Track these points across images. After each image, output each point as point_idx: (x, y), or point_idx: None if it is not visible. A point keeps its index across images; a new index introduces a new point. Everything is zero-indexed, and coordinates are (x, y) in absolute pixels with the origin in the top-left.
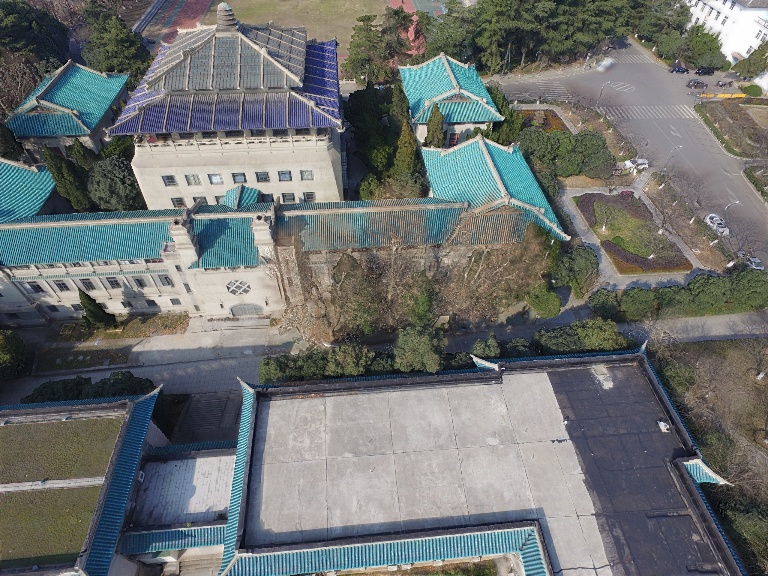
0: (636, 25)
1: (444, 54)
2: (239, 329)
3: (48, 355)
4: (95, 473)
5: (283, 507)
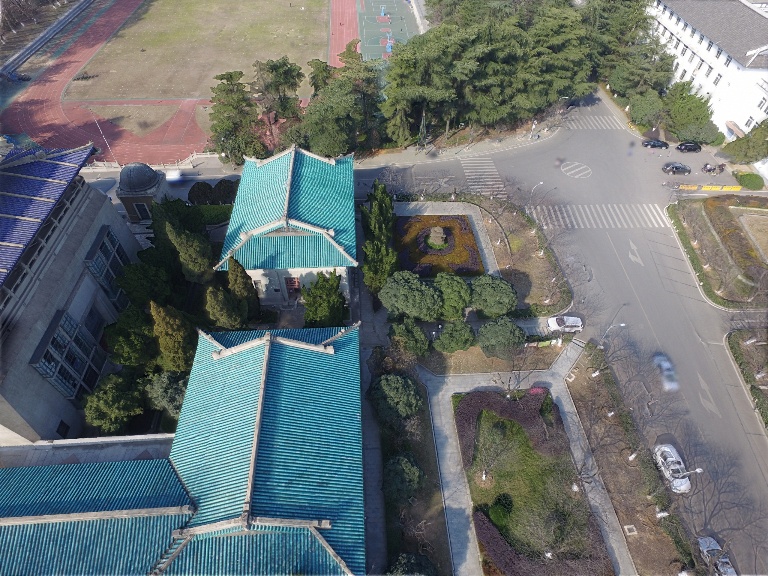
0: (606, 76)
1: (296, 147)
2: None
3: None
4: None
5: None
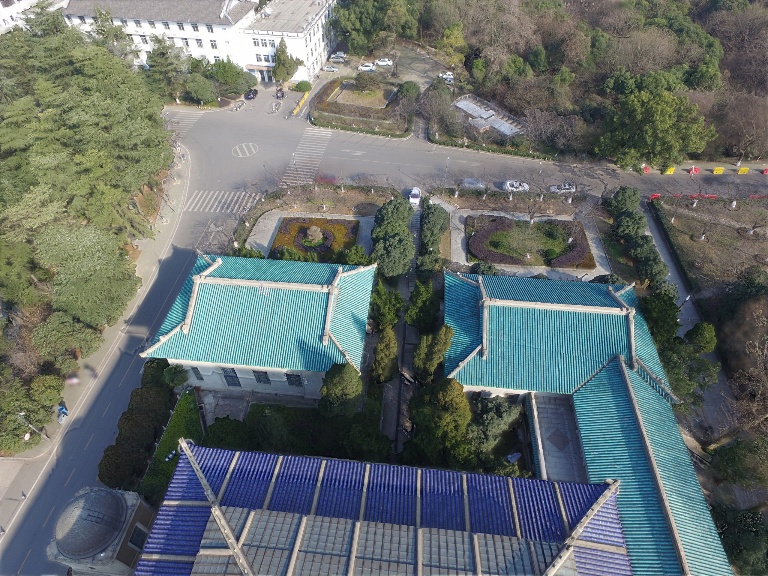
0: None
1: (198, 276)
2: None
3: None
4: None
5: None
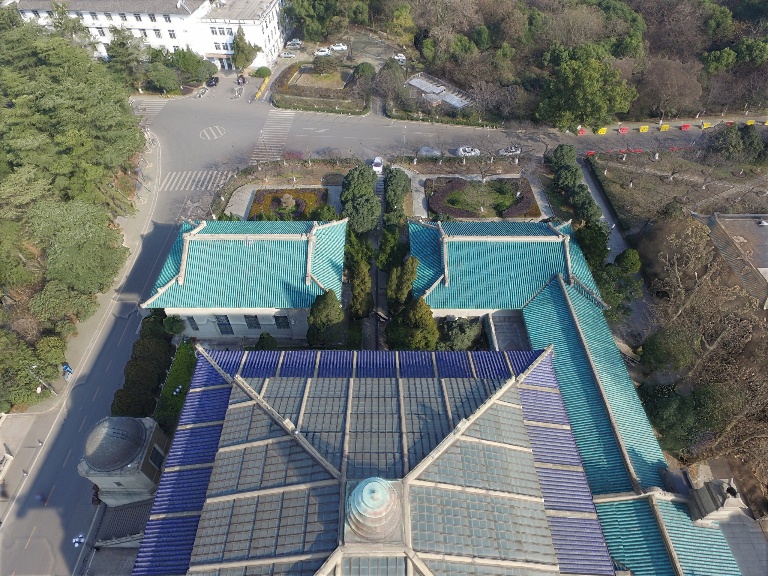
0: None
1: (188, 234)
2: None
3: None
4: None
5: None
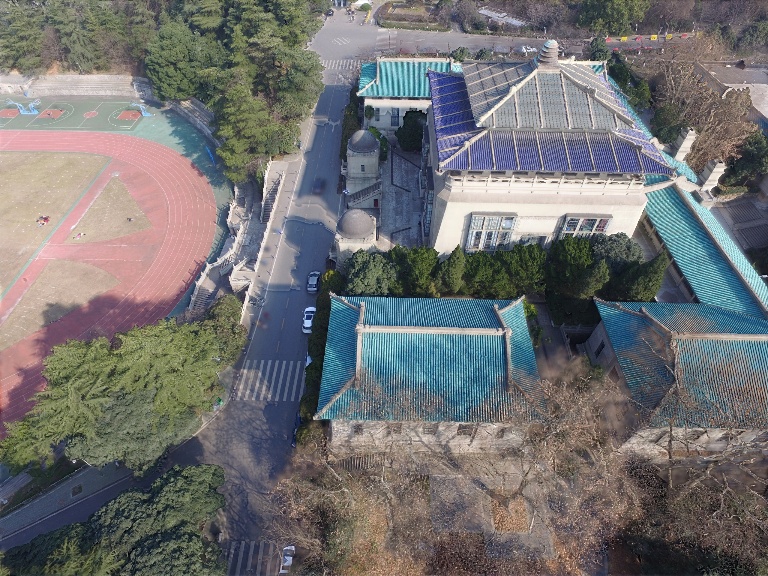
0: None
1: None
2: None
3: None
4: None
5: None
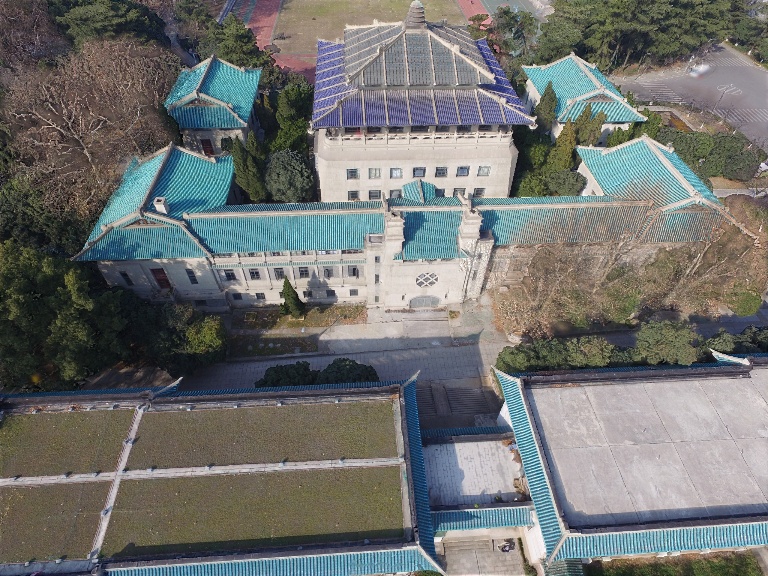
0: (731, 28)
1: None
2: (420, 321)
3: (239, 341)
4: (387, 453)
5: (585, 491)
